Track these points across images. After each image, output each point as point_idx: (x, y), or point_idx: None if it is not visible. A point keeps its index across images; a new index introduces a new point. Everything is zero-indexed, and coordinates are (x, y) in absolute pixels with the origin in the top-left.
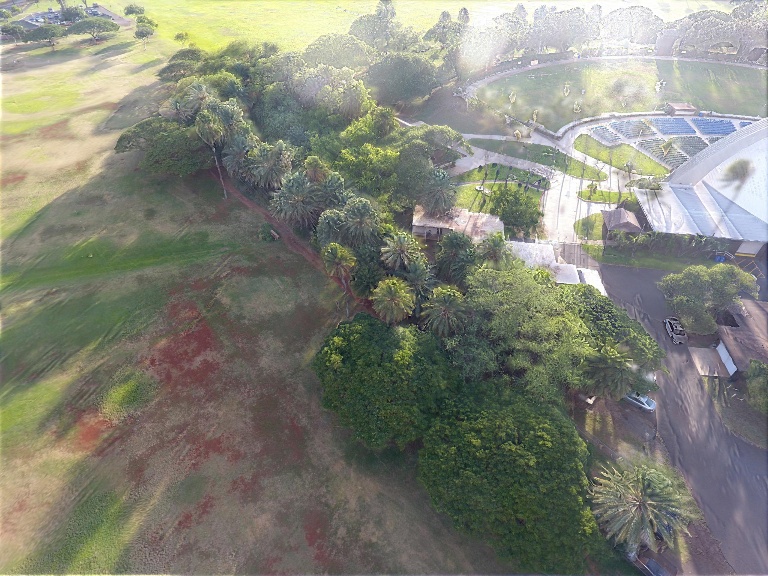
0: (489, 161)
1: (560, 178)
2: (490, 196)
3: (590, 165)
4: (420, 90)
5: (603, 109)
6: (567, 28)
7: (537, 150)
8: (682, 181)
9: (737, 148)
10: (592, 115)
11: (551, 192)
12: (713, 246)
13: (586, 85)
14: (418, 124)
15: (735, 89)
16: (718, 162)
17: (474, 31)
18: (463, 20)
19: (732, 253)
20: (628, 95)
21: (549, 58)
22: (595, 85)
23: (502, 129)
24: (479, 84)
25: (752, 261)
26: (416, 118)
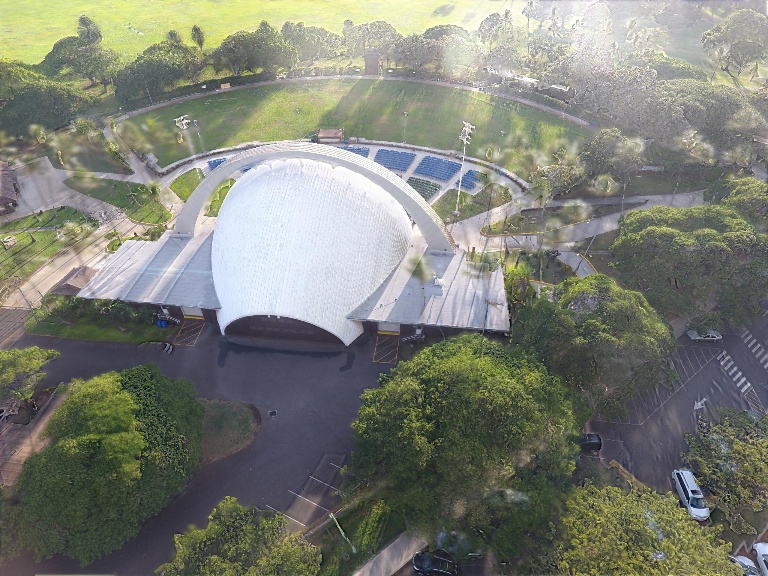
0: (62, 204)
1: (115, 223)
2: (7, 249)
3: (165, 206)
4: (46, 122)
5: (247, 138)
6: (250, 49)
7: (125, 189)
8: (178, 230)
9: (202, 195)
10: (227, 145)
11: (84, 241)
12: (128, 313)
13: (257, 110)
14: (39, 160)
15: (409, 111)
16: (196, 210)
17: (191, 52)
18: (196, 39)
19: (179, 316)
20: (291, 121)
21: (244, 80)
22: (267, 110)
23: (111, 165)
24: (136, 112)
25: (202, 324)
26: (44, 153)
